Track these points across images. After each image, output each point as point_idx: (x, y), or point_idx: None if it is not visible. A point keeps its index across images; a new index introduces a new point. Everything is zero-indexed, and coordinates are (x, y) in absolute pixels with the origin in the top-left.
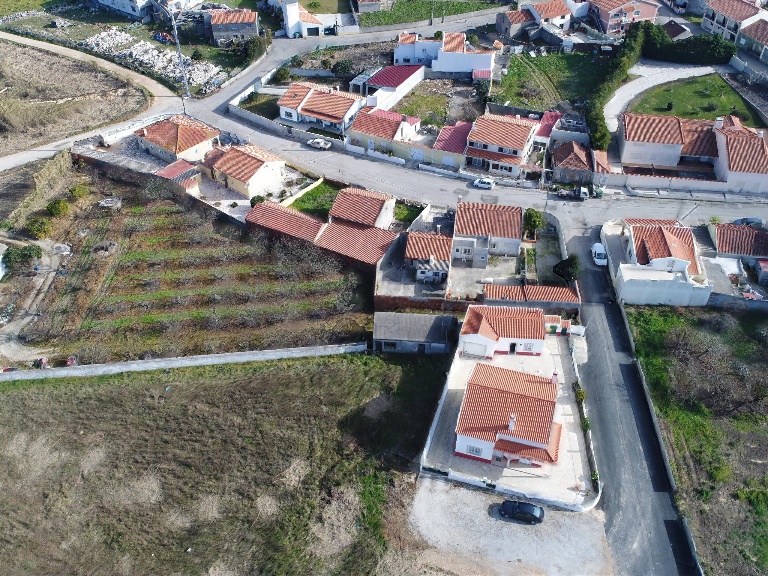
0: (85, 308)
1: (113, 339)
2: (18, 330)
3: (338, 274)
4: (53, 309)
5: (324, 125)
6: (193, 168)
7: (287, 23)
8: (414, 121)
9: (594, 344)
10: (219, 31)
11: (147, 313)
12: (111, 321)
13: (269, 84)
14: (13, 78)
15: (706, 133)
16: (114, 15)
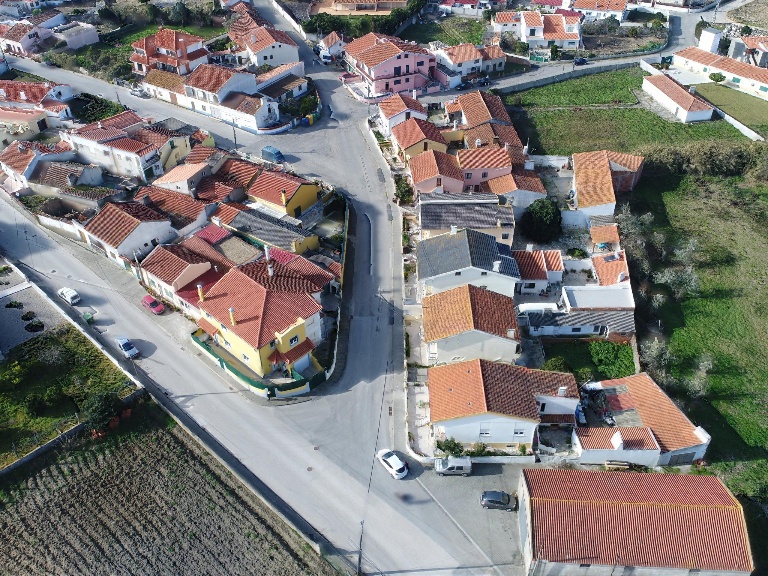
0: None
1: None
2: None
3: None
4: None
5: None
6: None
7: None
8: (534, 0)
9: None
10: None
11: None
12: None
13: None
14: None
15: None
16: None
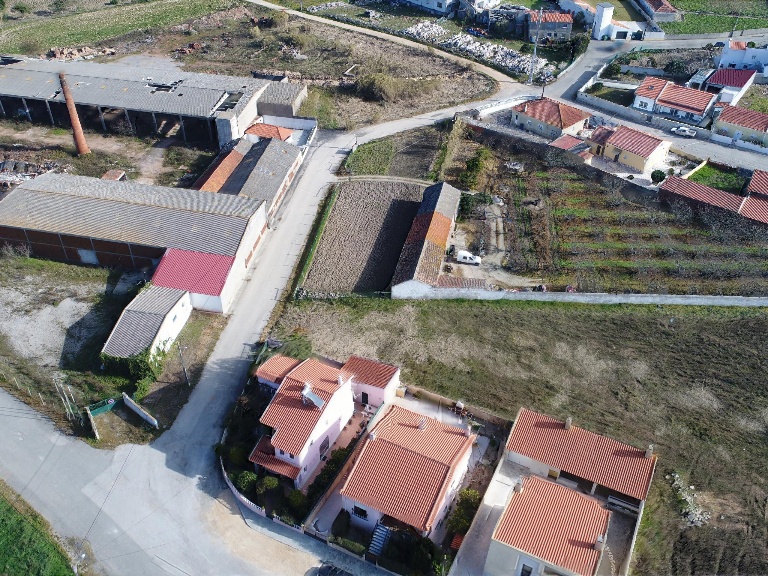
0: (548, 250)
1: (592, 276)
2: (499, 262)
3: (767, 243)
4: (519, 248)
5: (681, 116)
6: (582, 142)
7: (599, 26)
8: None
9: None
10: (536, 29)
11: (608, 259)
12: (579, 262)
13: (602, 78)
14: (357, 57)
15: None
16: (416, 10)
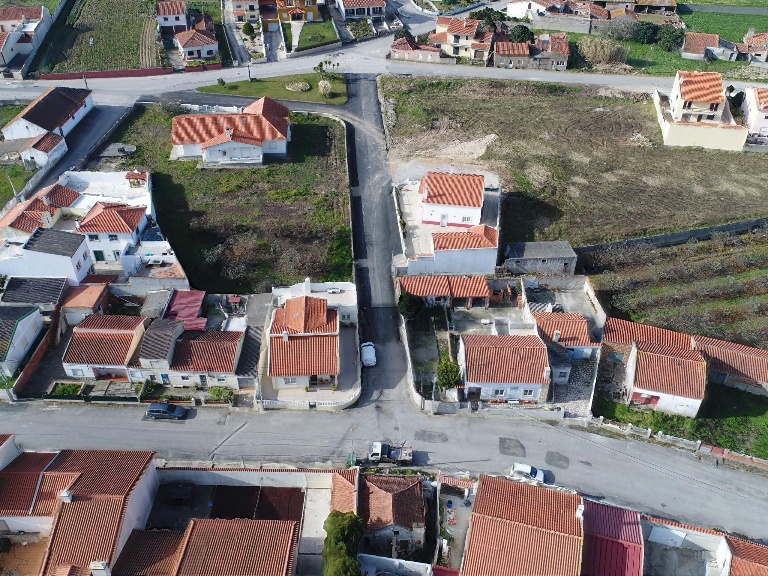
0: None
1: None
2: None
3: None
4: None
5: None
6: None
7: None
8: None
9: (386, 270)
10: None
11: None
12: None
13: None
14: None
15: (128, 575)
16: None
